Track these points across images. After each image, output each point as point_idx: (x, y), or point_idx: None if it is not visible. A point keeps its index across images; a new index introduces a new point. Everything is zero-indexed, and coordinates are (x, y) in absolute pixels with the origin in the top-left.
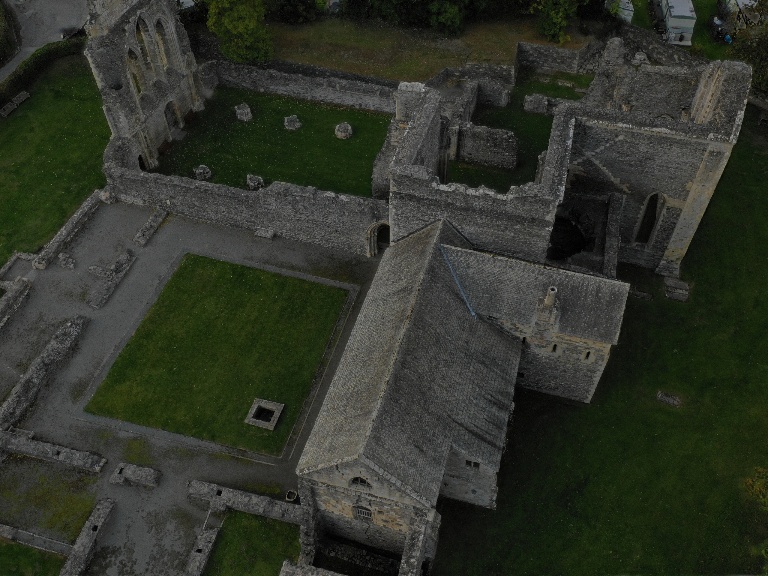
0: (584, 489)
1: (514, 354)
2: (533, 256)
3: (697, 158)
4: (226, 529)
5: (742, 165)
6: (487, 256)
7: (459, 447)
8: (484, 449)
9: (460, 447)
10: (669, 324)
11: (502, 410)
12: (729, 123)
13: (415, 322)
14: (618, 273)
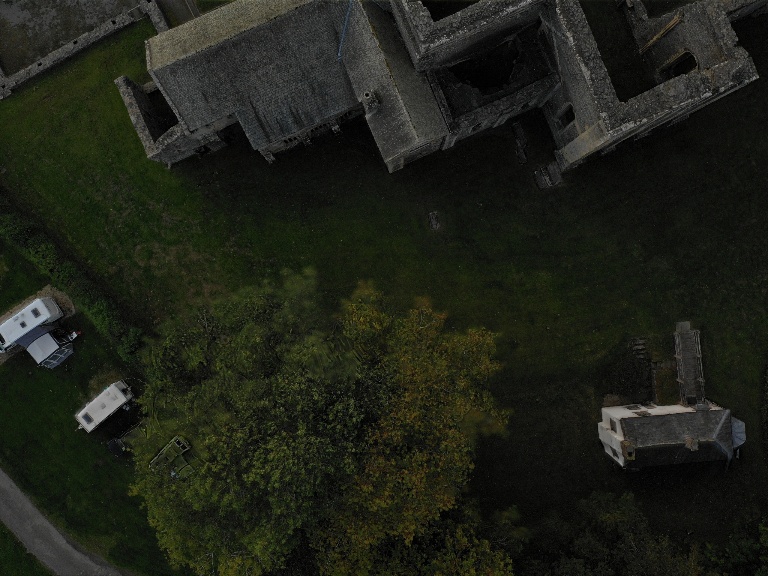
0: (323, 206)
1: (346, 103)
2: (413, 59)
3: (595, 117)
4: (138, 25)
5: (766, 155)
6: (370, 29)
7: (239, 118)
8: (257, 132)
9: (240, 118)
10: (504, 188)
11: (296, 124)
12: (620, 121)
13: (272, 26)
14: (532, 125)
